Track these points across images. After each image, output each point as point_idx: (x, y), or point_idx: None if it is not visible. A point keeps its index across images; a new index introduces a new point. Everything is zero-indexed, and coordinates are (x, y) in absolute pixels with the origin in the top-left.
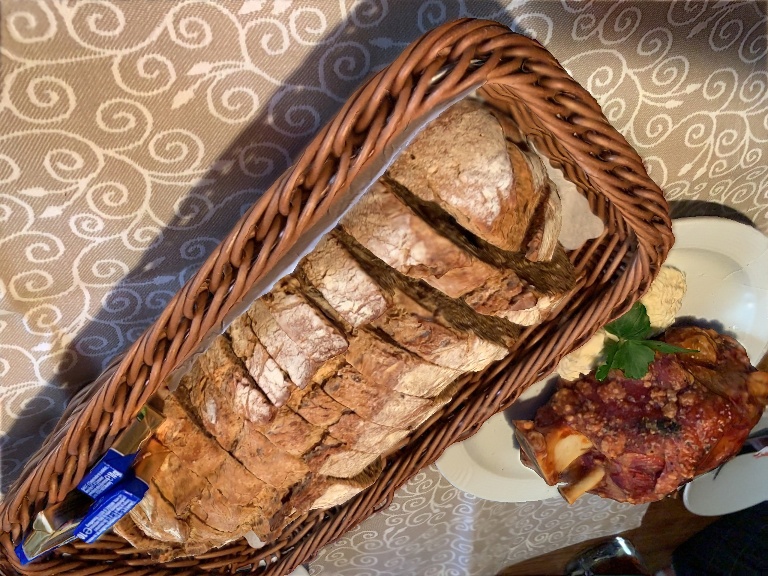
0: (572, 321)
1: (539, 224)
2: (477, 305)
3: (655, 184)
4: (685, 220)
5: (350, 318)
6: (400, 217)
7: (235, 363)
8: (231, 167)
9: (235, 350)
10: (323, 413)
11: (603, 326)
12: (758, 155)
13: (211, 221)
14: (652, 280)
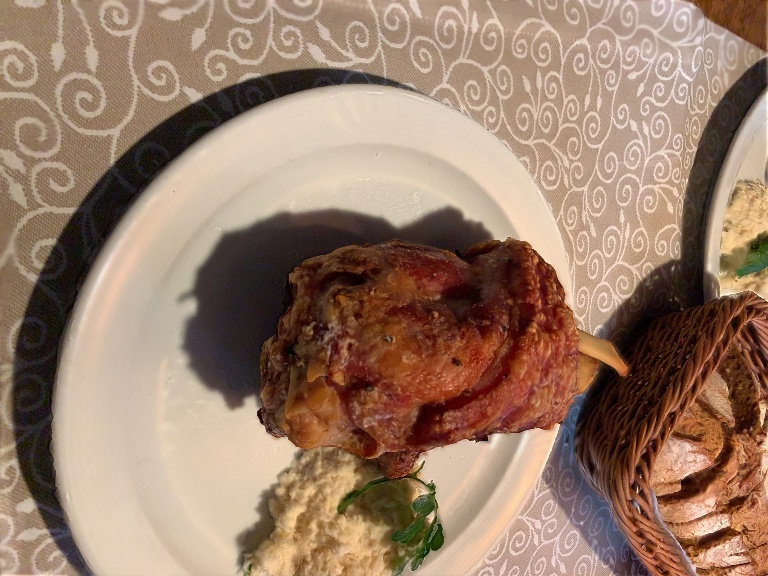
0: (764, 350)
1: (710, 409)
2: (748, 461)
3: (715, 336)
4: (712, 222)
5: (723, 527)
6: (685, 506)
7: (713, 570)
8: (595, 540)
9: (706, 569)
10: (765, 535)
11: (758, 272)
12: (678, 137)
13: (615, 547)
14: (764, 303)
